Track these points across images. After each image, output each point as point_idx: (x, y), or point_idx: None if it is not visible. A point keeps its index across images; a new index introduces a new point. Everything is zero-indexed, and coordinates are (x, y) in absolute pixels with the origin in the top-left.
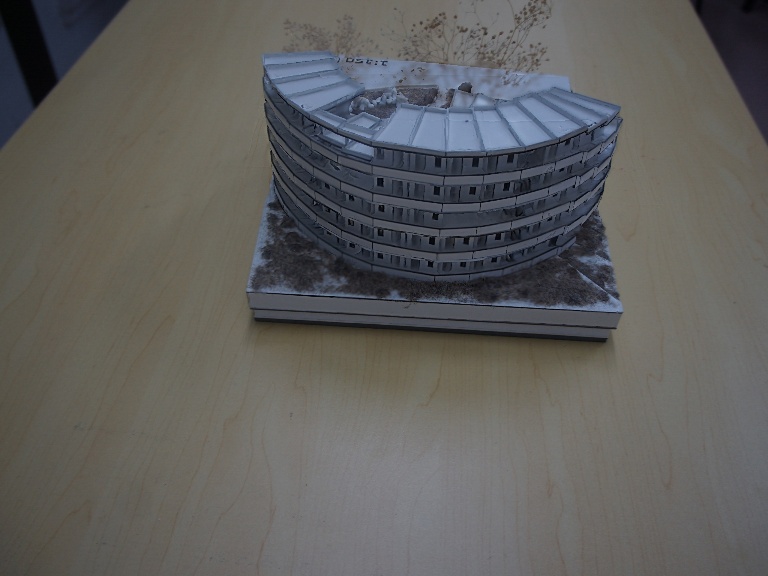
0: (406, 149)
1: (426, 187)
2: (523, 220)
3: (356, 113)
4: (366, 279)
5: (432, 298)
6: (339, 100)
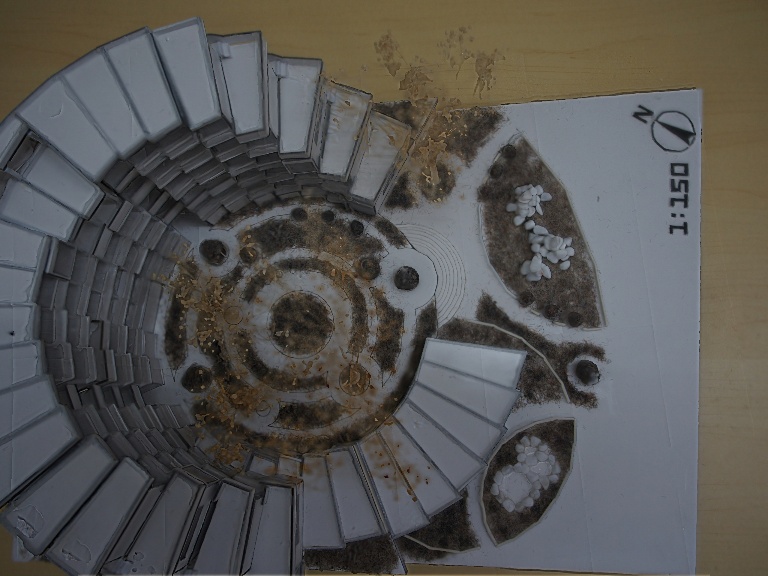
0: None
1: None
2: None
3: (499, 200)
4: None
5: None
6: (66, 149)
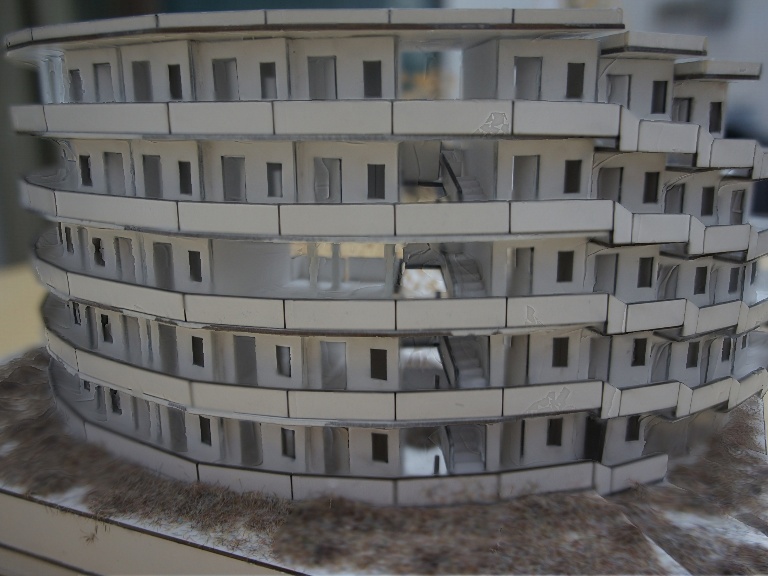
0: (86, 30)
1: (164, 172)
2: (436, 306)
3: None
4: (52, 452)
5: (155, 520)
6: None
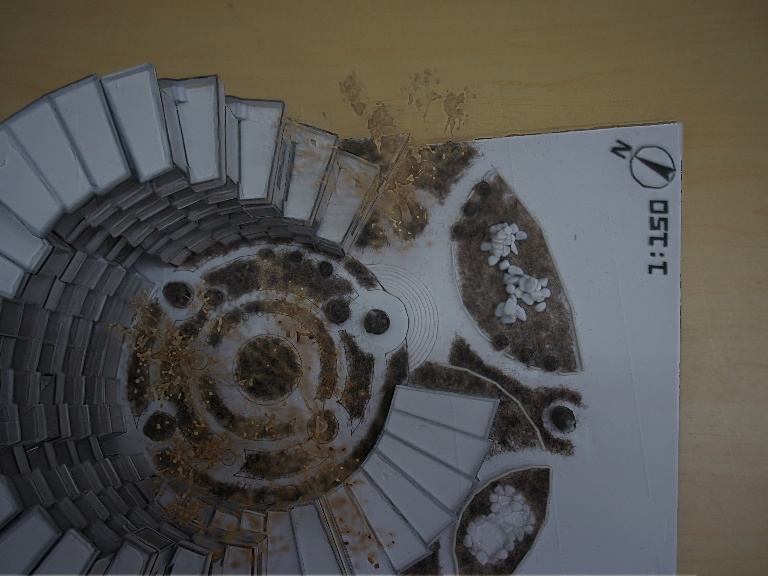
0: None
1: None
2: None
3: (473, 239)
4: None
5: None
6: (10, 202)
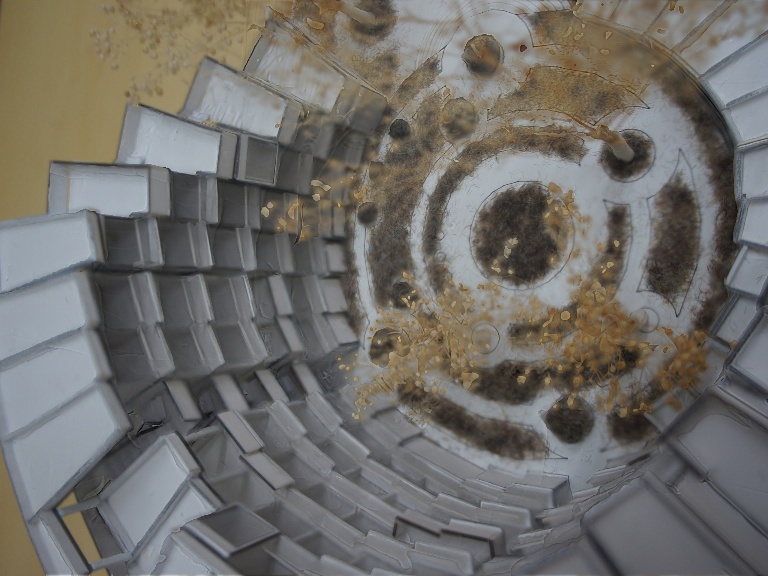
0: None
1: None
2: None
3: None
4: None
5: None
6: (82, 462)
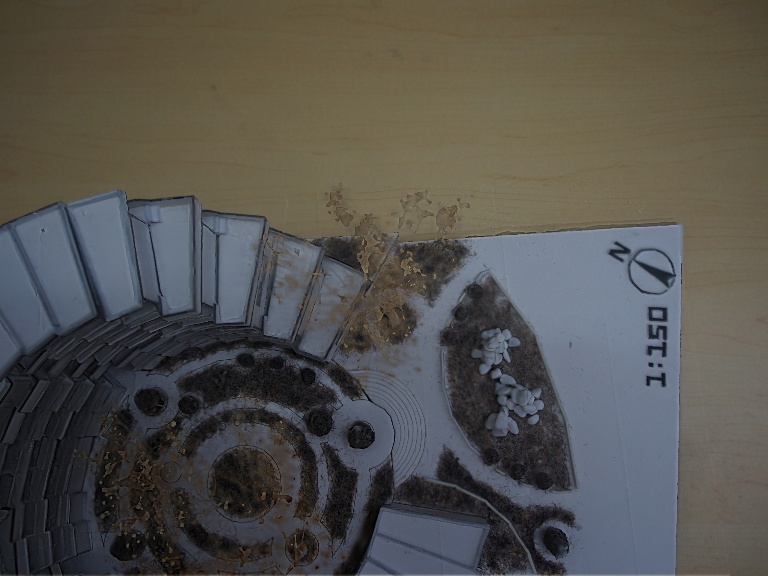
0: None
1: None
2: None
3: (464, 345)
4: None
5: None
6: None
